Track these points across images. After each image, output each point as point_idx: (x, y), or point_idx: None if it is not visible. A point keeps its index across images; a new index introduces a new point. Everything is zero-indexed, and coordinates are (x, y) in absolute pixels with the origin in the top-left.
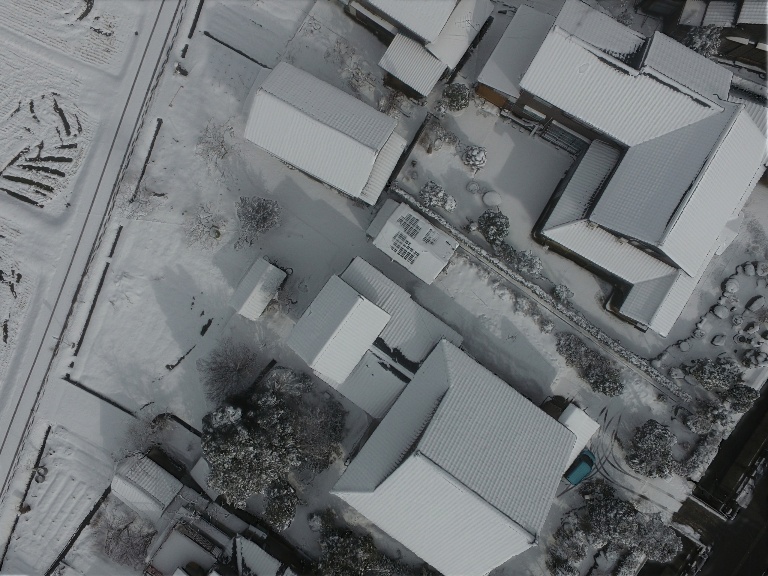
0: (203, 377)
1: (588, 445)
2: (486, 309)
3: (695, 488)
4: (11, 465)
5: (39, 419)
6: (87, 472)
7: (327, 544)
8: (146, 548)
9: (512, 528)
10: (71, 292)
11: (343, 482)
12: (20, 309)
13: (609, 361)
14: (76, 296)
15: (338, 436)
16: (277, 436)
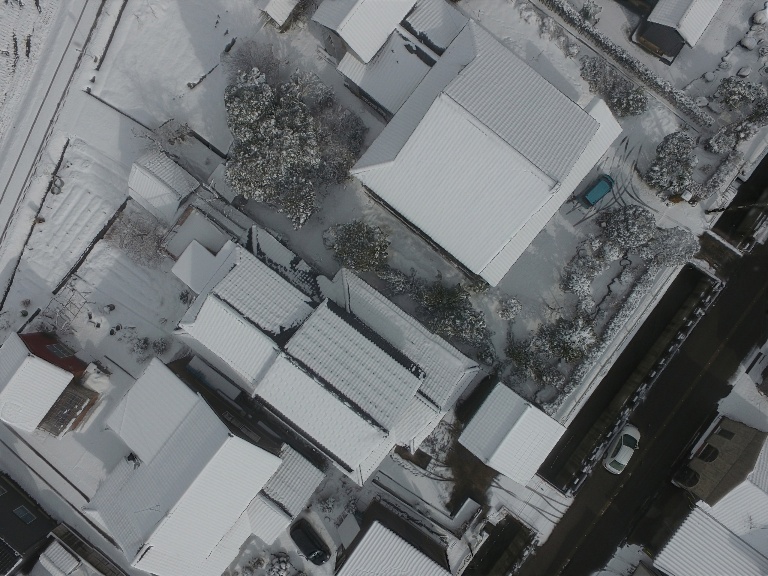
0: (226, 69)
1: (607, 174)
2: (512, 33)
3: (712, 230)
4: (28, 175)
5: (58, 130)
6: (103, 186)
7: (344, 227)
8: (161, 238)
9: (534, 174)
10: (96, 5)
11: (363, 160)
12: (44, 24)
13: (633, 88)
14: (101, 9)
15: (358, 146)
16: (299, 116)
